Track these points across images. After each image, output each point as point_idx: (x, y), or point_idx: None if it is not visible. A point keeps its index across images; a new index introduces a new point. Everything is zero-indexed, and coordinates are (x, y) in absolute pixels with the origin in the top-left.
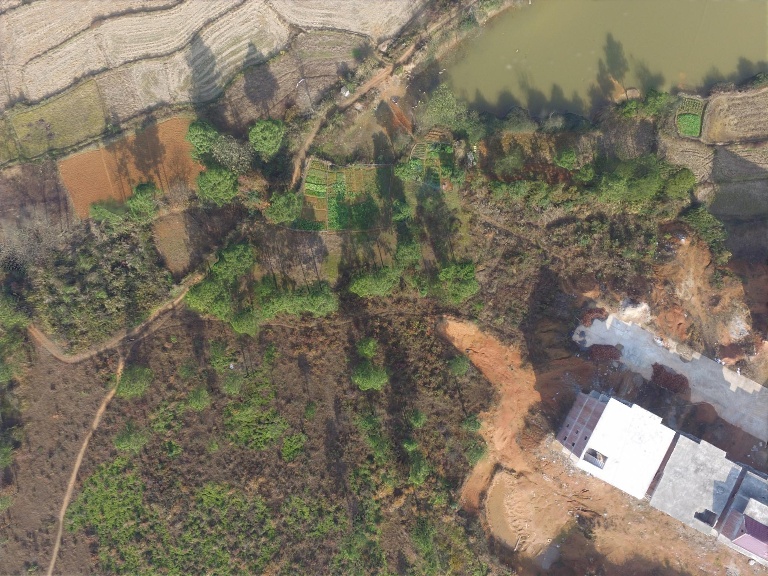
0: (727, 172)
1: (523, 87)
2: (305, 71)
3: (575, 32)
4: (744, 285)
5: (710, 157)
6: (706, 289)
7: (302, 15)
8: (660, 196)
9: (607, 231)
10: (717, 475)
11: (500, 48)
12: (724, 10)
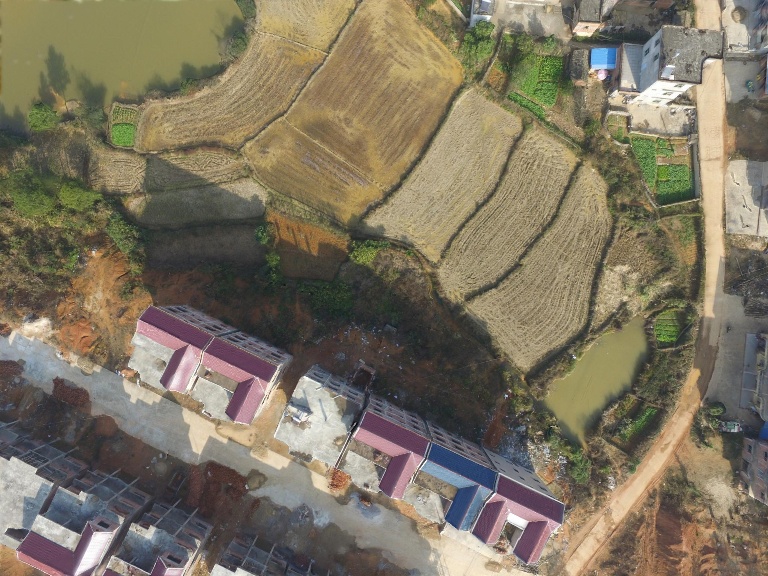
0: (160, 181)
1: None
2: None
3: (17, 46)
4: (152, 295)
5: (142, 166)
6: (115, 301)
7: None
8: (74, 209)
9: (26, 246)
10: (27, 491)
11: None
12: (167, 16)
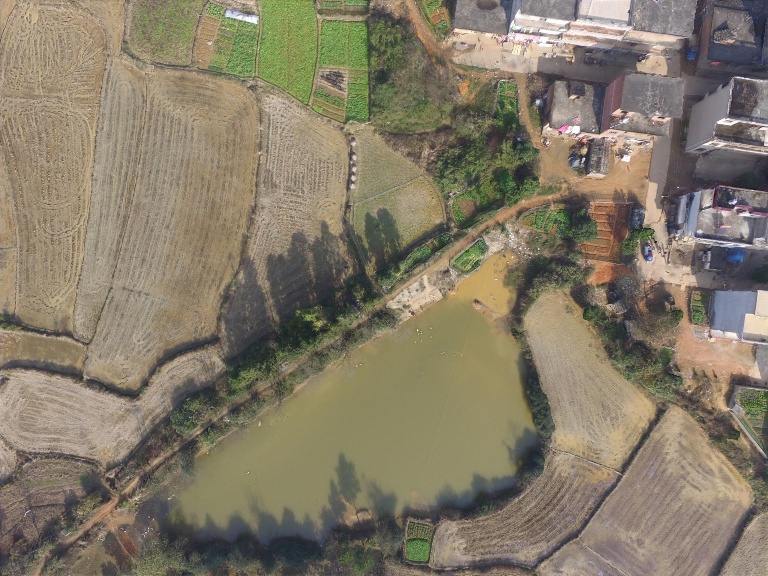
0: None
1: (253, 510)
2: (32, 501)
3: (306, 453)
4: None
5: None
6: None
7: (29, 441)
8: None
9: None
10: None
11: (230, 471)
12: (458, 426)
